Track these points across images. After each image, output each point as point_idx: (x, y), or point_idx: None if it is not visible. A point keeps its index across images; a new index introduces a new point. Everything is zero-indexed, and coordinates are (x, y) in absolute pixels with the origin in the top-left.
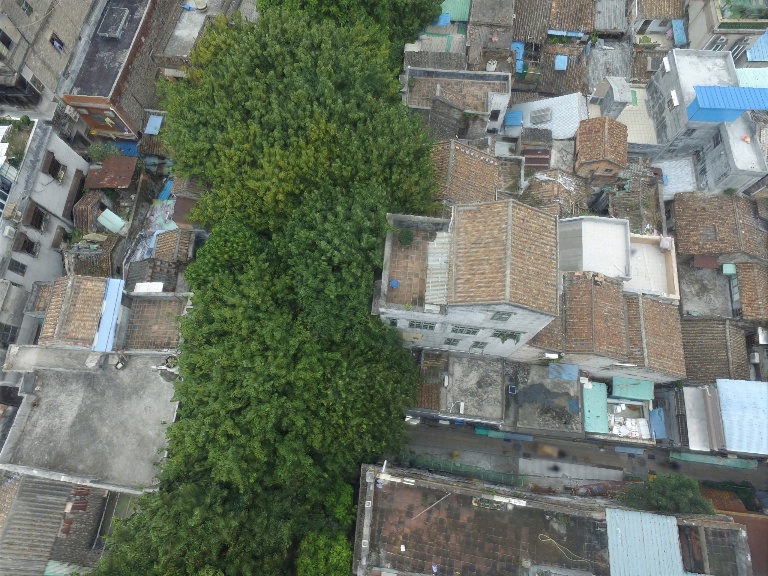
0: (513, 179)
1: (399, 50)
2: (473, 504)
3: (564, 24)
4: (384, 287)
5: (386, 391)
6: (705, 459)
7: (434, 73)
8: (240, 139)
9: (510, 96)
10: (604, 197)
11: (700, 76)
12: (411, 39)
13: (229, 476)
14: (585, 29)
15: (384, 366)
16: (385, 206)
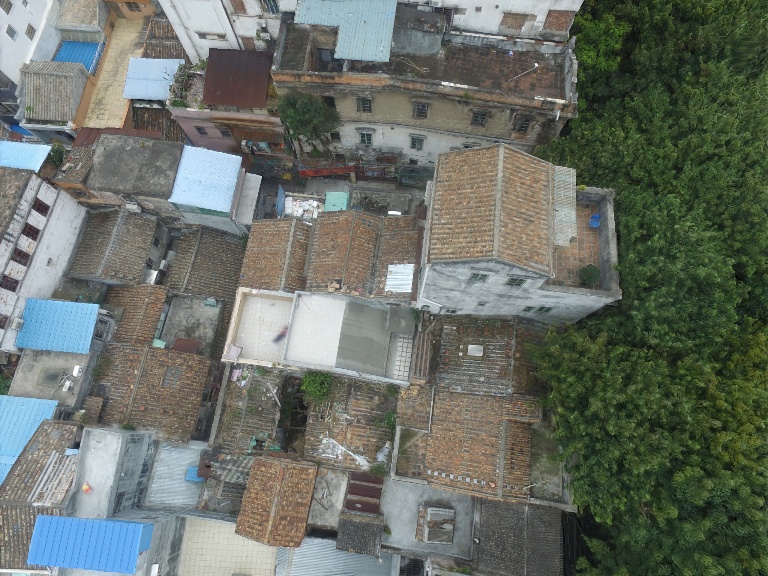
0: (405, 450)
1: None
2: None
3: None
4: (611, 210)
5: None
6: None
7: None
8: None
9: None
10: None
11: None
12: None
13: (716, 67)
14: None
15: None
16: (619, 322)
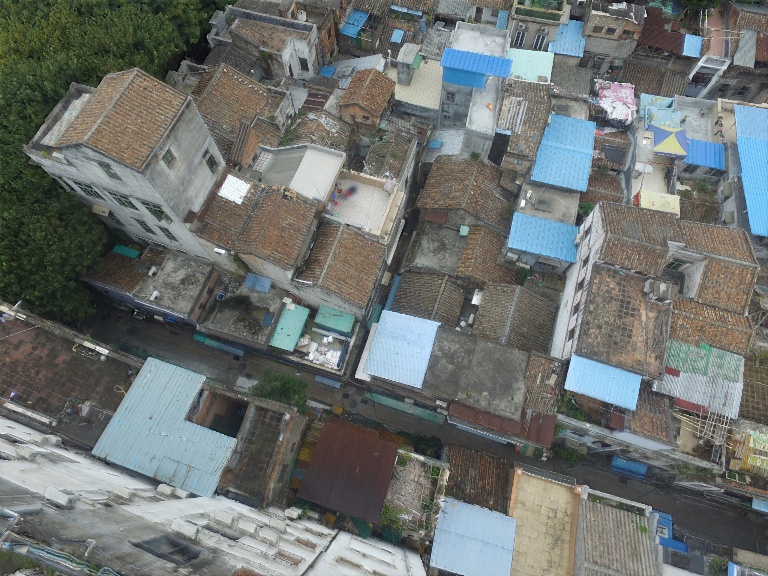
0: None
1: None
2: (72, 349)
3: (405, 1)
4: (36, 137)
5: (41, 241)
6: (396, 405)
7: (251, 15)
8: None
9: (307, 43)
10: None
11: (475, 49)
12: None
13: None
14: (423, 8)
15: (53, 223)
16: (86, 82)
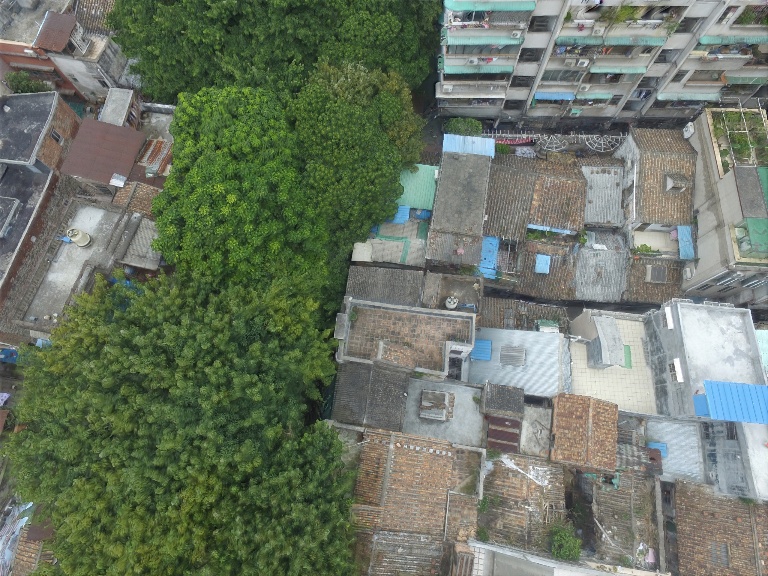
0: (471, 474)
1: (345, 254)
2: None
3: (547, 219)
4: None
5: None
6: None
7: (381, 307)
8: (91, 496)
9: (473, 347)
10: (587, 479)
11: (711, 341)
12: (361, 239)
13: None
14: (572, 227)
15: None
16: None
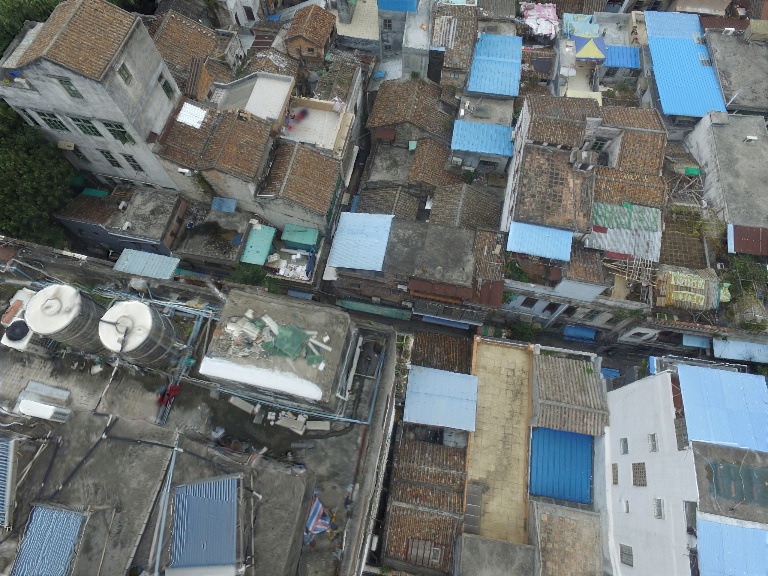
0: None
1: None
2: None
3: None
4: None
5: None
6: (366, 308)
7: None
8: None
9: None
10: None
11: None
12: None
13: None
14: None
15: (21, 156)
16: None
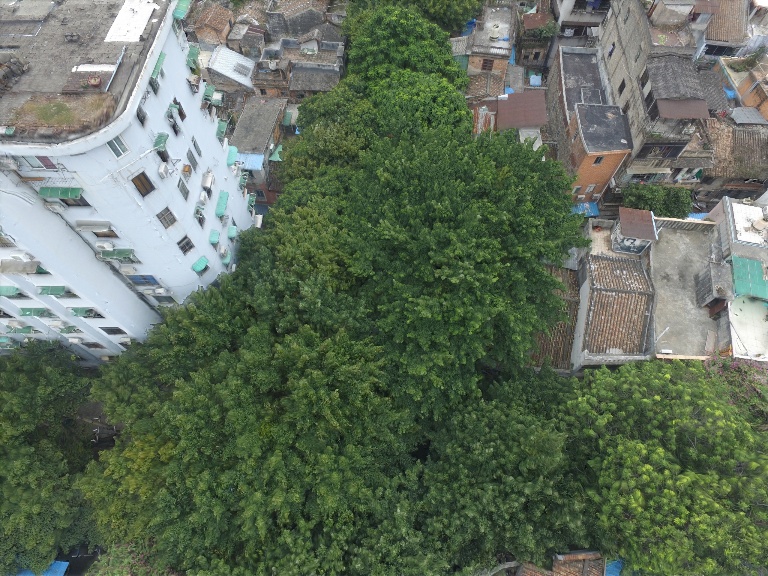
0: None
1: None
2: None
3: None
4: None
5: None
6: None
7: None
8: None
9: None
10: None
11: None
12: None
13: None
14: None
15: None
16: None
